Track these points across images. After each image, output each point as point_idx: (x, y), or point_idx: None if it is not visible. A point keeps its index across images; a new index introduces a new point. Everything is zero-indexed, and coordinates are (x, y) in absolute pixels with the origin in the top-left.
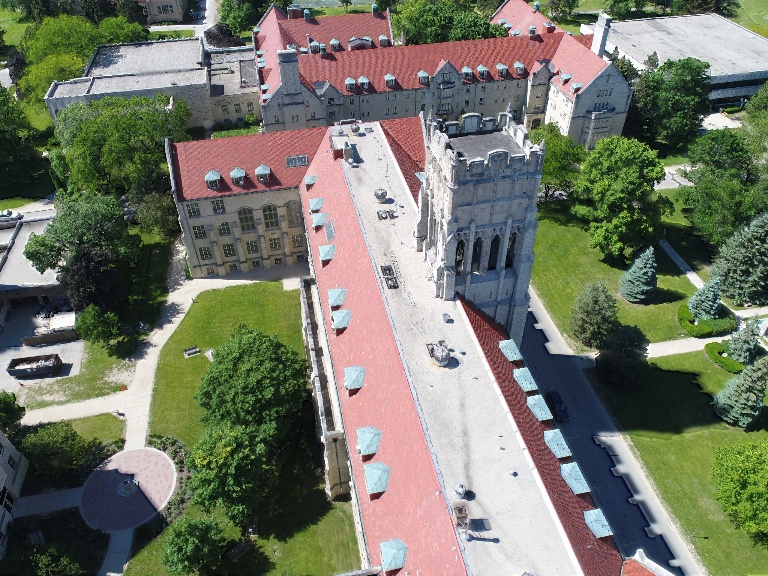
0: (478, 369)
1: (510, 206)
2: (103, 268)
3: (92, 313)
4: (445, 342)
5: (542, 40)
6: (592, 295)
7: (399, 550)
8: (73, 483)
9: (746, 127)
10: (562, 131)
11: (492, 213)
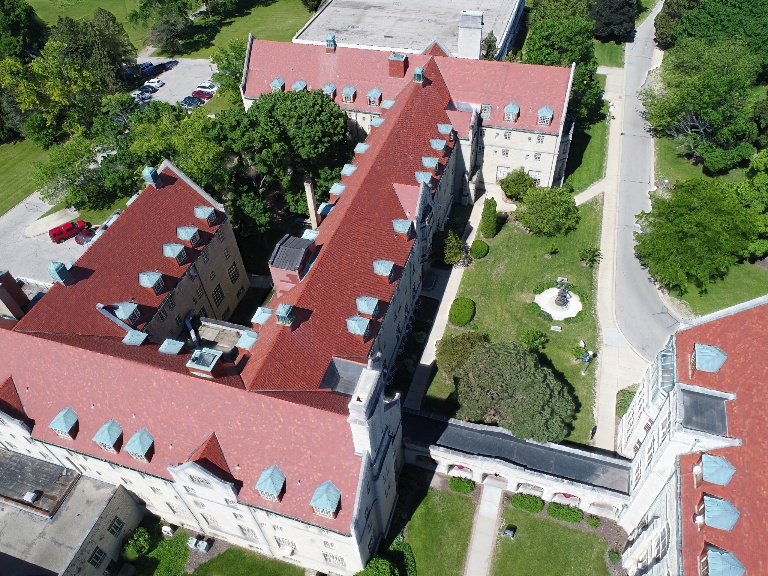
0: None
1: None
2: None
3: None
4: None
5: (429, 80)
6: None
7: None
8: None
9: (693, 63)
10: (535, 174)
11: None
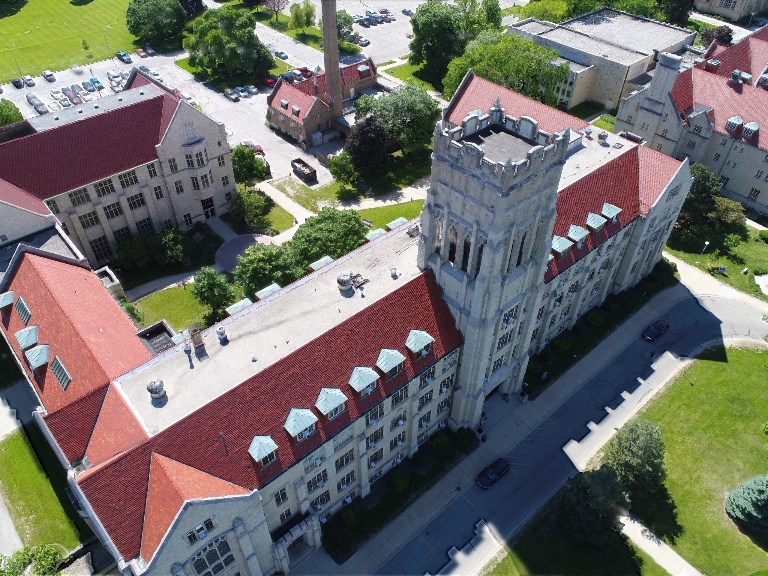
0: (351, 309)
1: (478, 211)
2: (372, 135)
3: (341, 157)
4: (368, 282)
5: None
6: (633, 429)
7: (185, 336)
8: (238, 230)
9: None
10: None
11: (463, 207)
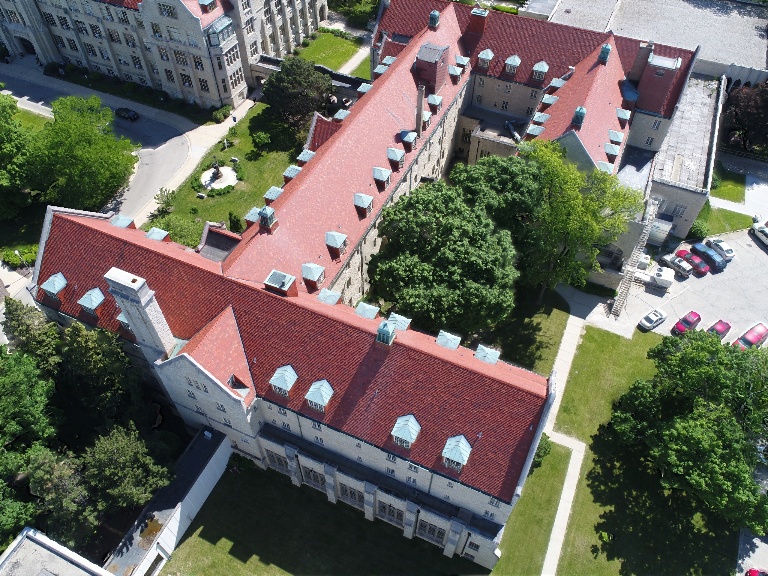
0: None
1: None
2: None
3: None
4: None
5: (250, 240)
6: None
7: None
8: None
9: None
10: None
11: None
